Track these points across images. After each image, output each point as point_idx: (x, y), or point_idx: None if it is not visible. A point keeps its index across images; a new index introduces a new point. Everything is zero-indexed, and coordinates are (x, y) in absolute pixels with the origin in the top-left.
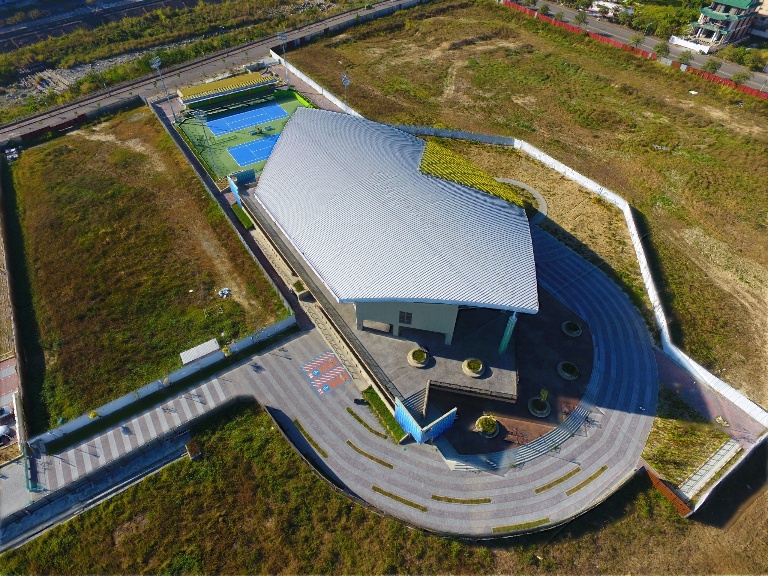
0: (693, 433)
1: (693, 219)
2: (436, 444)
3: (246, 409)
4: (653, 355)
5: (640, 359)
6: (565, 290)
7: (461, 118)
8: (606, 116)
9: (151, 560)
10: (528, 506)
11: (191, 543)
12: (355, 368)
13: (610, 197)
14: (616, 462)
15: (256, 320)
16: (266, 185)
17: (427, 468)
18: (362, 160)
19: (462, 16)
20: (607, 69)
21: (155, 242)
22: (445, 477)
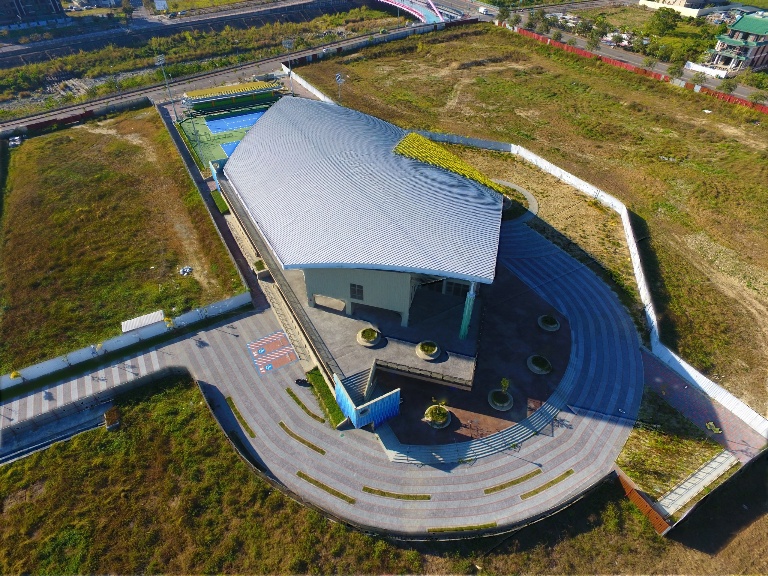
0: (680, 441)
1: (698, 225)
2: (378, 432)
3: (177, 381)
4: (640, 356)
5: (624, 359)
6: (547, 285)
7: (460, 126)
8: (611, 129)
9: (36, 532)
10: (473, 507)
11: (84, 517)
12: (304, 349)
13: (607, 200)
14: (584, 467)
15: (212, 298)
16: (236, 161)
17: (363, 457)
18: (335, 140)
19: (475, 42)
20: (617, 89)
21: (128, 221)
22: (382, 468)
